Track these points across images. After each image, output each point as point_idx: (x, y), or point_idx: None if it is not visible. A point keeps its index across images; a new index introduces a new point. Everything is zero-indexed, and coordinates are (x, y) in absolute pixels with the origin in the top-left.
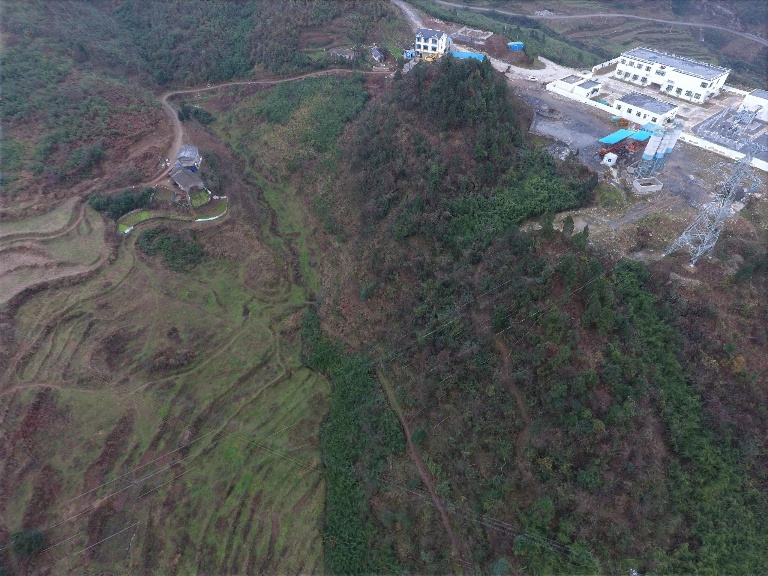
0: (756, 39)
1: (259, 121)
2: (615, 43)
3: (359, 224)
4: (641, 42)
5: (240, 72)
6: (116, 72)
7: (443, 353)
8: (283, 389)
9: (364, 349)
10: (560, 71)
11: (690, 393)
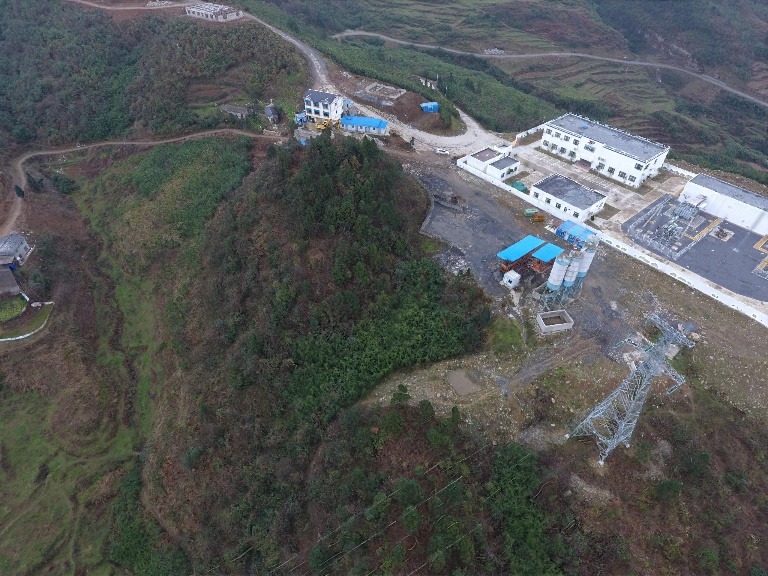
0: (714, 81)
1: (128, 192)
2: (567, 85)
3: (207, 347)
4: (595, 84)
5: (116, 130)
6: None
7: None
8: None
9: None
10: (480, 138)
11: None
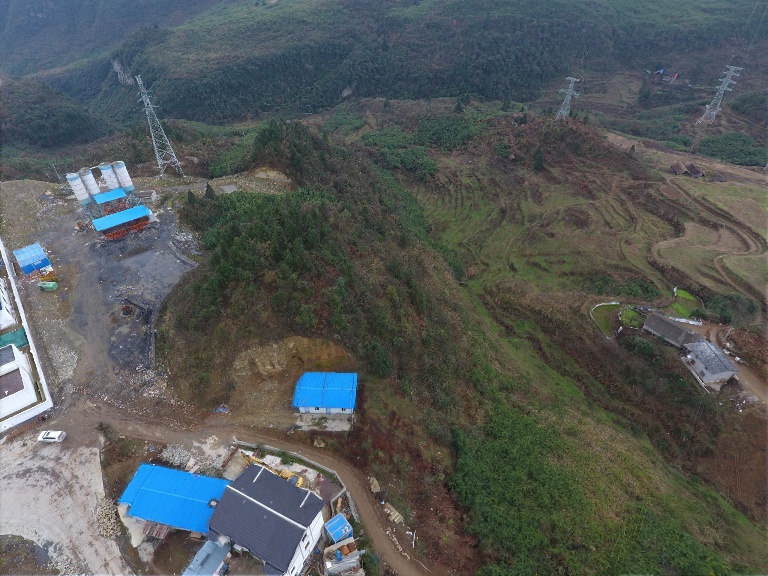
0: None
1: (723, 554)
2: None
3: None
4: None
5: None
6: None
7: None
8: None
9: None
10: None
11: None
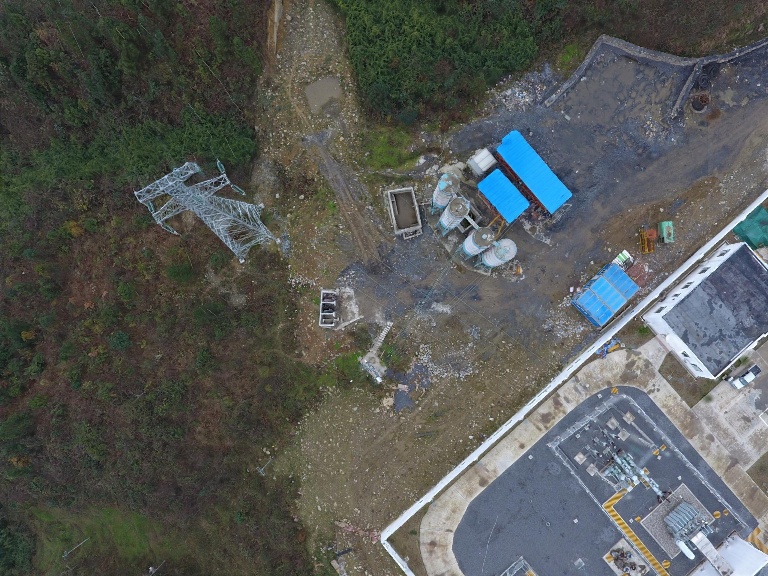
0: None
1: None
2: None
3: None
4: None
5: None
6: None
7: None
8: None
9: None
10: None
11: None
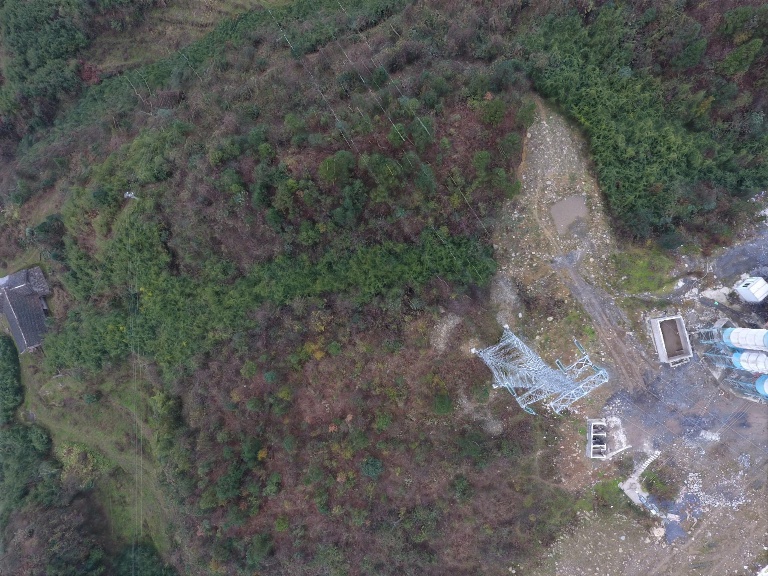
0: None
1: None
2: None
3: None
4: None
5: None
6: None
7: (364, 45)
8: None
9: None
10: None
11: (294, 297)
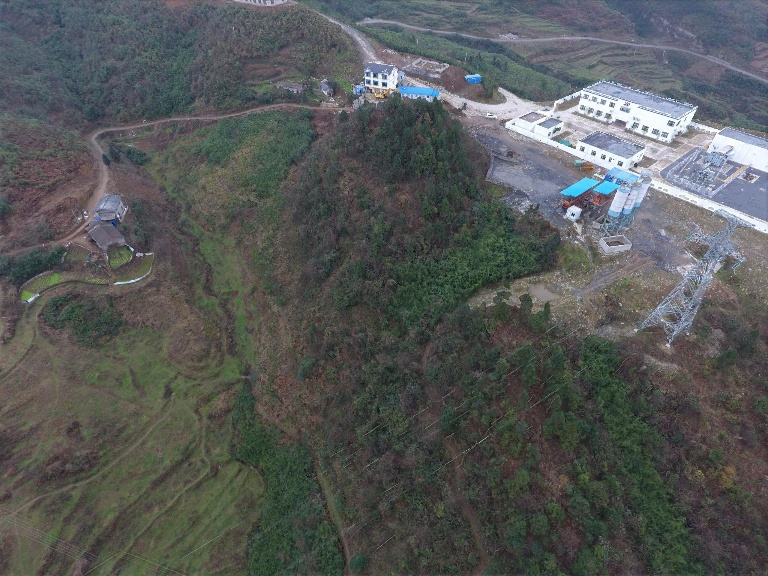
0: (718, 61)
1: (198, 162)
2: (580, 67)
3: (300, 285)
4: (606, 65)
5: (179, 107)
6: (35, 110)
7: (385, 458)
8: (206, 491)
9: (302, 438)
10: (521, 105)
11: (673, 513)
